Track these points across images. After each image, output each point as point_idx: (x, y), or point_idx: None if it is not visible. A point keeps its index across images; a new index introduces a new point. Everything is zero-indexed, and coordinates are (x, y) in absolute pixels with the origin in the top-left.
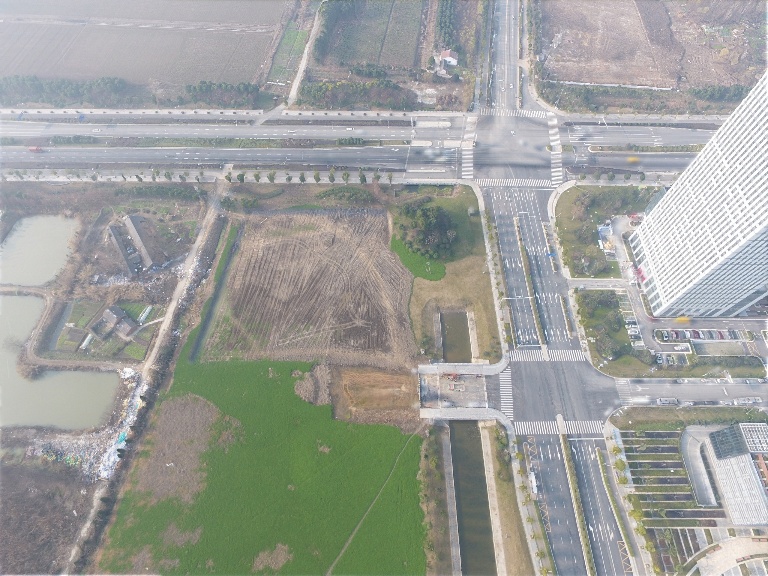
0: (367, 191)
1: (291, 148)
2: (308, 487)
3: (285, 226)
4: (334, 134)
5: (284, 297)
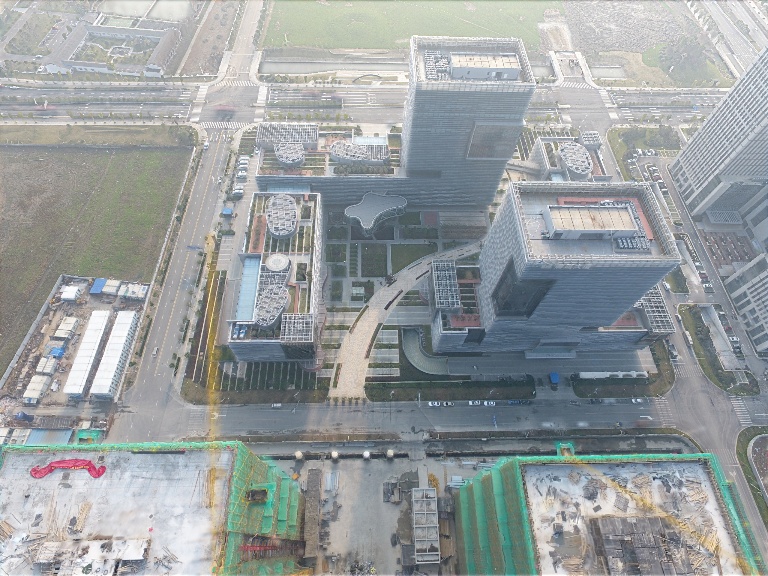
0: (701, 35)
1: (718, 4)
2: (502, 14)
3: (651, 3)
4: (746, 22)
5: (601, 5)
